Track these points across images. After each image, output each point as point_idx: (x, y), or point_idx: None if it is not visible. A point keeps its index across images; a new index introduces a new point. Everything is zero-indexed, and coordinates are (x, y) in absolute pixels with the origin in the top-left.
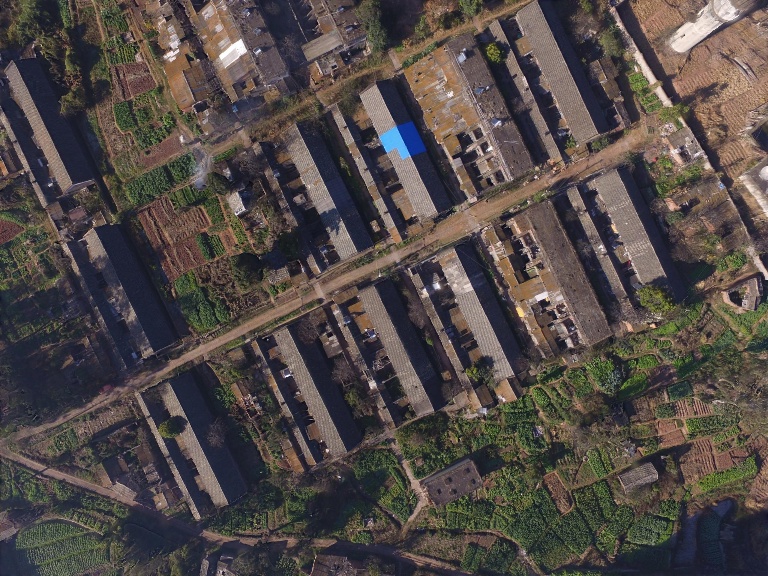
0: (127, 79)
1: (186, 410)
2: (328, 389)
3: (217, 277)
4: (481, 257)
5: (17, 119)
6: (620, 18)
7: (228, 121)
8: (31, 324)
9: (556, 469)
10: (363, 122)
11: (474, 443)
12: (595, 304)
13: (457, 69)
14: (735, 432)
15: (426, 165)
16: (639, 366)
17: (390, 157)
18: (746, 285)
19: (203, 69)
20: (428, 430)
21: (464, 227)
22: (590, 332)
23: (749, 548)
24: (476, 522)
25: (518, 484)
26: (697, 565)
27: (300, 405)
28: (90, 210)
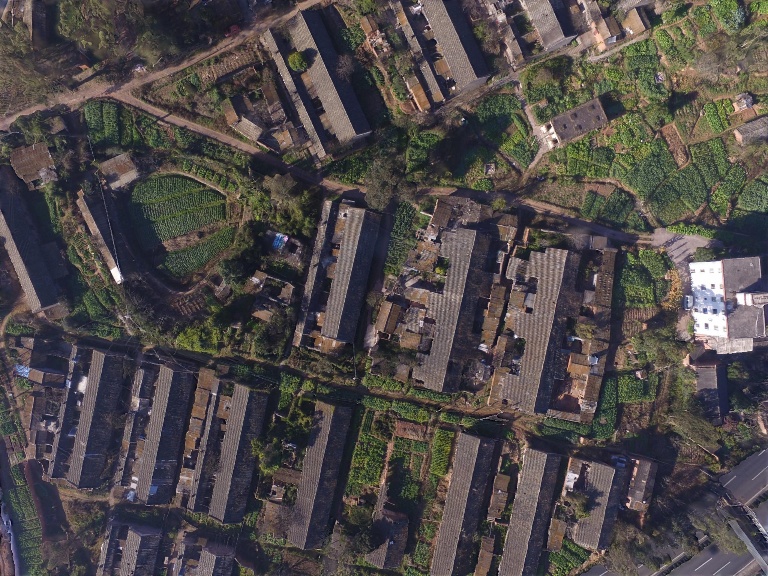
0: None
1: (316, 41)
2: (458, 20)
3: None
4: None
5: None
6: None
7: None
8: None
9: (674, 120)
10: None
11: (597, 87)
12: None
13: None
14: None
15: None
16: (760, 11)
17: None
18: None
19: None
20: (553, 72)
21: None
22: None
23: None
24: (596, 169)
25: (638, 131)
26: None
27: (427, 44)
28: None
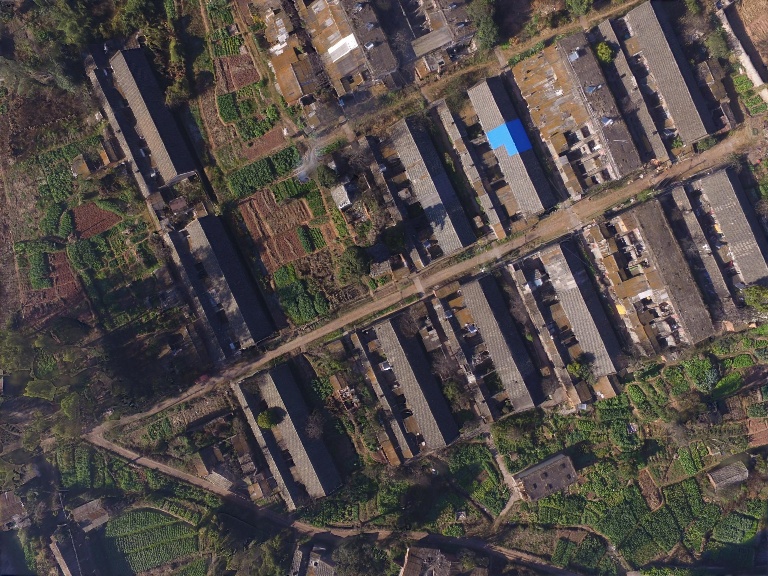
0: (231, 71)
1: (285, 401)
2: (428, 383)
3: (317, 270)
4: (583, 254)
5: (120, 109)
6: (727, 20)
7: (334, 115)
8: (127, 313)
9: (647, 466)
10: (469, 118)
11: (568, 439)
12: (700, 303)
13: (568, 67)
14: None
15: (532, 162)
16: (734, 365)
17: (496, 153)
18: None
19: (311, 63)
20: (523, 425)
21: (566, 224)
22: (694, 330)
23: None
24: (568, 517)
25: (610, 480)
26: None
27: (397, 398)
28: (192, 201)
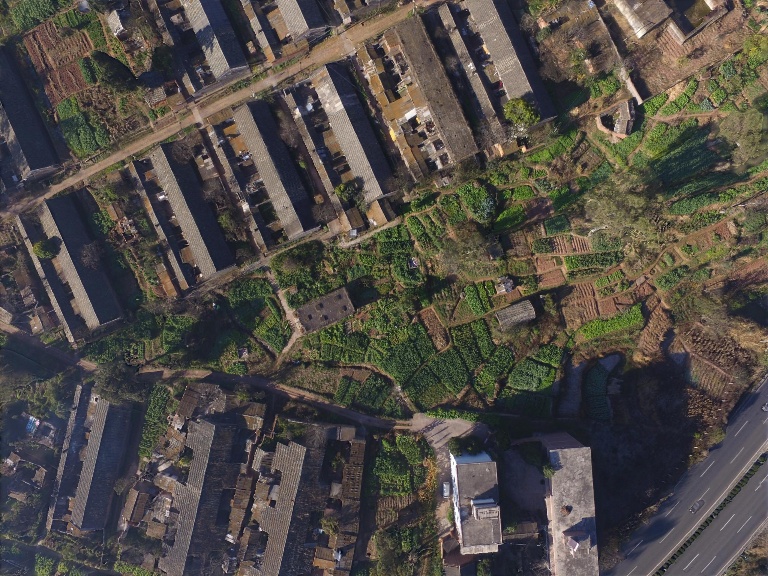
0: None
1: (61, 230)
2: (201, 210)
3: (98, 101)
4: (355, 79)
5: None
6: None
7: None
8: None
9: (433, 304)
10: None
11: (349, 273)
12: (462, 120)
13: None
14: (618, 276)
15: None
16: (515, 197)
17: None
18: (619, 110)
19: None
20: (303, 258)
21: (340, 51)
22: (456, 147)
23: (636, 403)
24: (350, 355)
25: (393, 316)
26: (581, 417)
27: (176, 230)
28: None
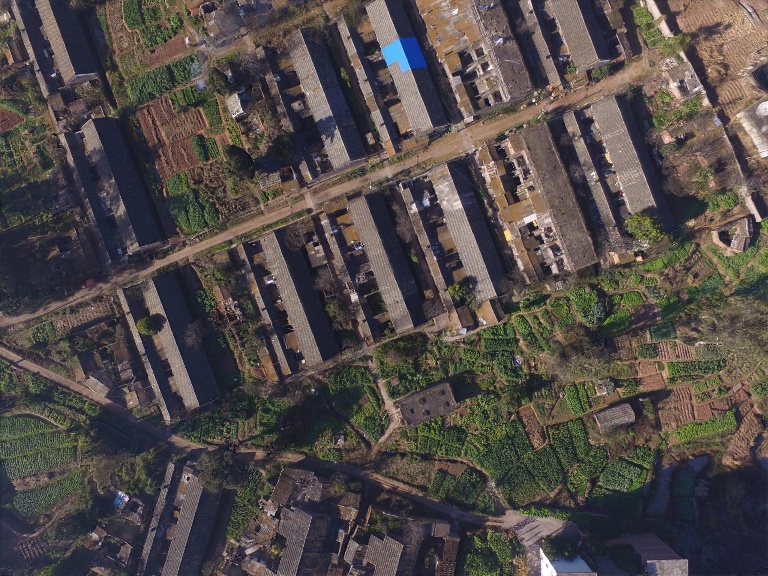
0: None
1: (166, 308)
2: (309, 298)
3: (209, 179)
4: (473, 177)
5: (27, 9)
6: None
7: (234, 24)
8: (21, 214)
9: (532, 402)
10: (367, 34)
11: (452, 367)
12: (583, 229)
13: None
14: (716, 382)
15: (425, 80)
16: (623, 302)
17: (390, 70)
18: (736, 226)
19: None
20: (406, 350)
21: (459, 147)
22: (576, 256)
23: (723, 506)
24: (447, 448)
25: (493, 413)
26: (669, 518)
27: (280, 314)
28: (90, 102)
